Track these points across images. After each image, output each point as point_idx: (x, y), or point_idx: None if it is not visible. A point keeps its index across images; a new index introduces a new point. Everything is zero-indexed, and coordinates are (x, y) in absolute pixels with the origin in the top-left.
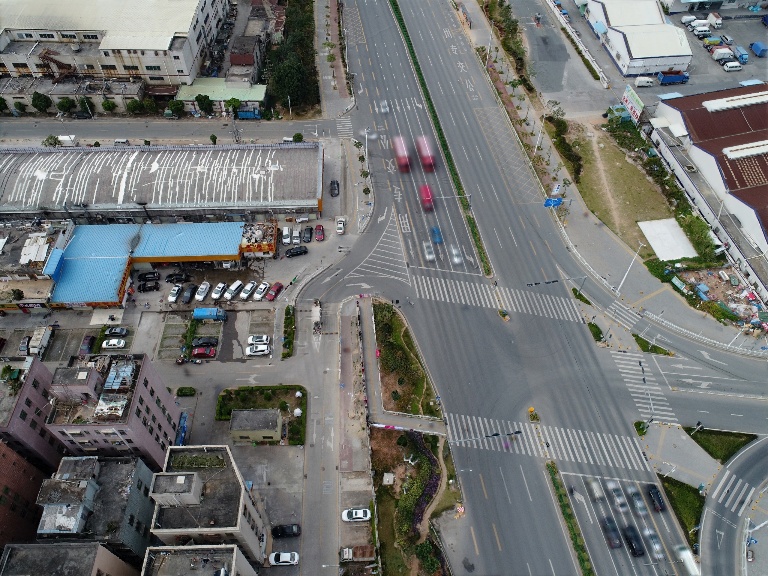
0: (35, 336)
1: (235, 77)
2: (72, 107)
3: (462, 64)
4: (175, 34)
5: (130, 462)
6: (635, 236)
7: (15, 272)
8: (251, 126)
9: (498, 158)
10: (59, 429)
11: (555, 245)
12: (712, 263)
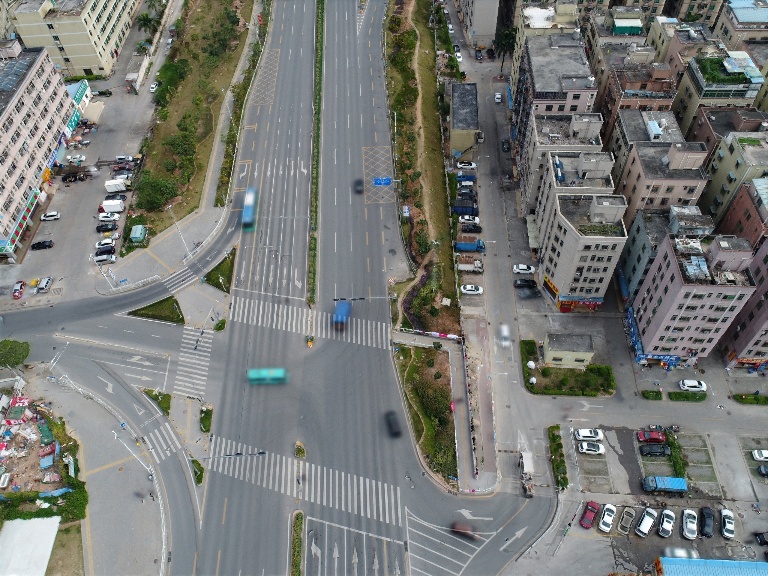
0: None
1: None
2: None
3: None
4: None
5: None
6: (60, 571)
7: None
8: None
9: None
10: None
11: (184, 567)
12: (5, 495)
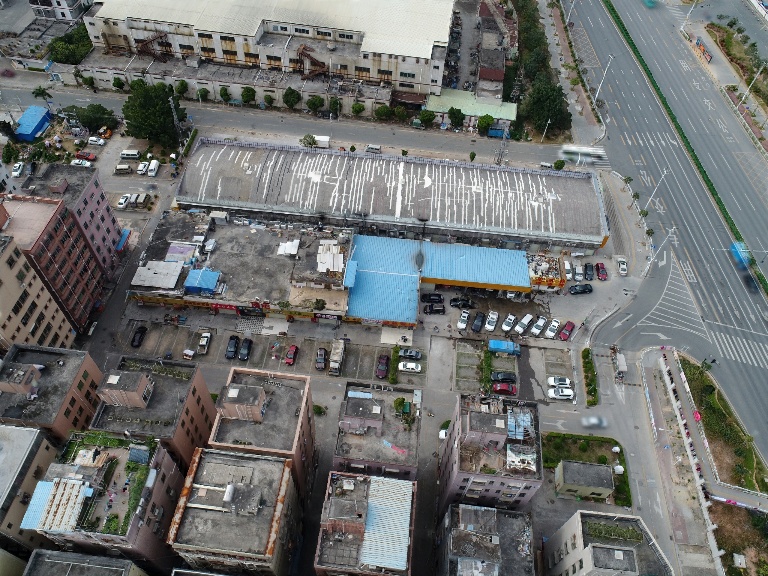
0: (334, 349)
1: (486, 92)
2: (320, 106)
3: (709, 101)
4: (434, 43)
5: (518, 517)
6: None
7: (315, 280)
8: (500, 145)
9: None
10: (467, 476)
11: None
12: None
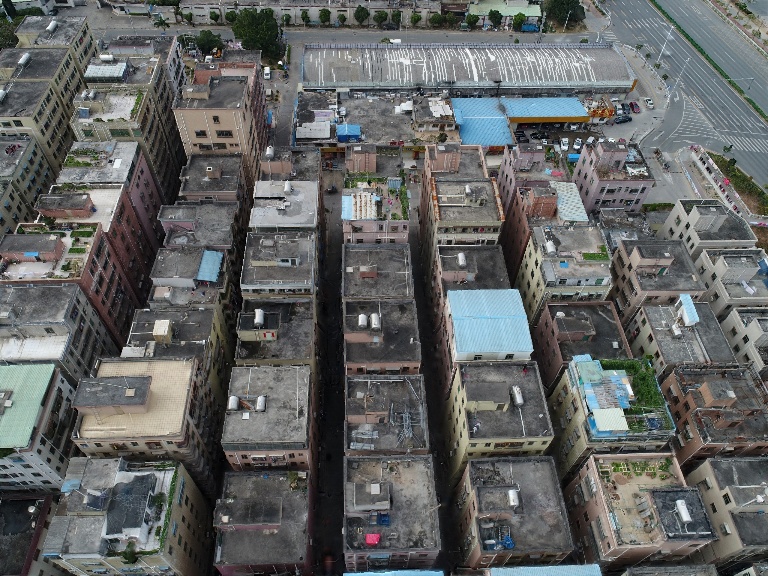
0: None
1: None
2: (384, 20)
3: None
4: None
5: (636, 217)
6: None
7: (434, 122)
8: (532, 37)
9: (747, 60)
10: (605, 185)
11: None
12: None
